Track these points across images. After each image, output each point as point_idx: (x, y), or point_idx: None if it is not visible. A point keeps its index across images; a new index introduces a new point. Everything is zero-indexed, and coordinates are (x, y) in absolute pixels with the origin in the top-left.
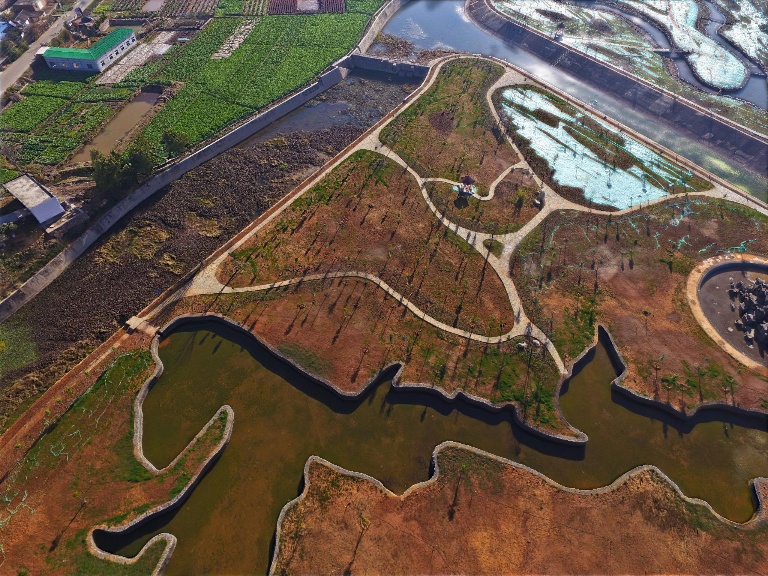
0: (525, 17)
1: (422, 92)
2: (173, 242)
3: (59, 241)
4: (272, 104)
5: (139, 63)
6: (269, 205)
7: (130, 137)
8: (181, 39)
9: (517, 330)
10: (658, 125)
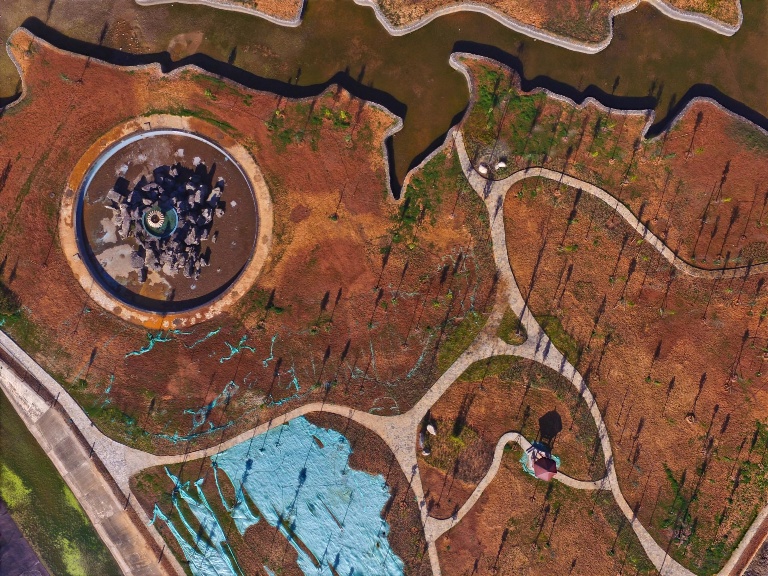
0: None
1: None
2: None
3: None
4: None
5: None
6: None
7: None
8: None
9: (503, 187)
10: None
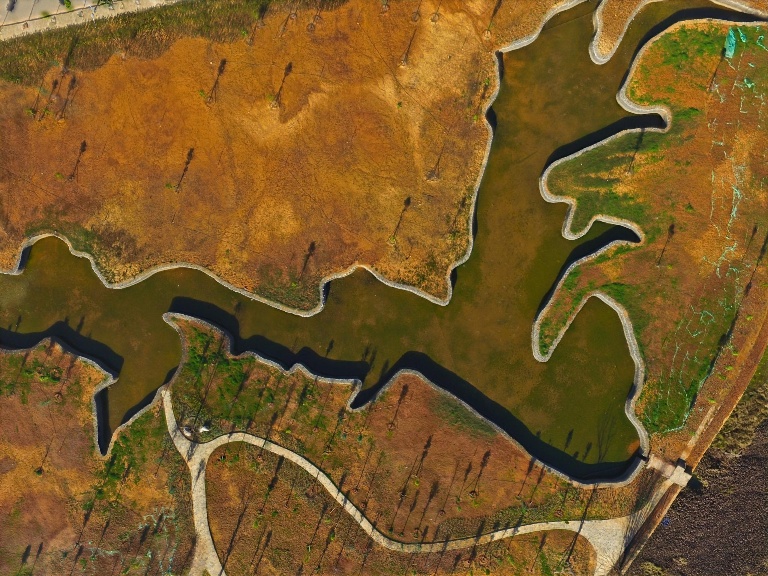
0: None
1: None
2: None
3: None
4: None
5: None
6: None
7: None
8: None
9: (206, 450)
10: None
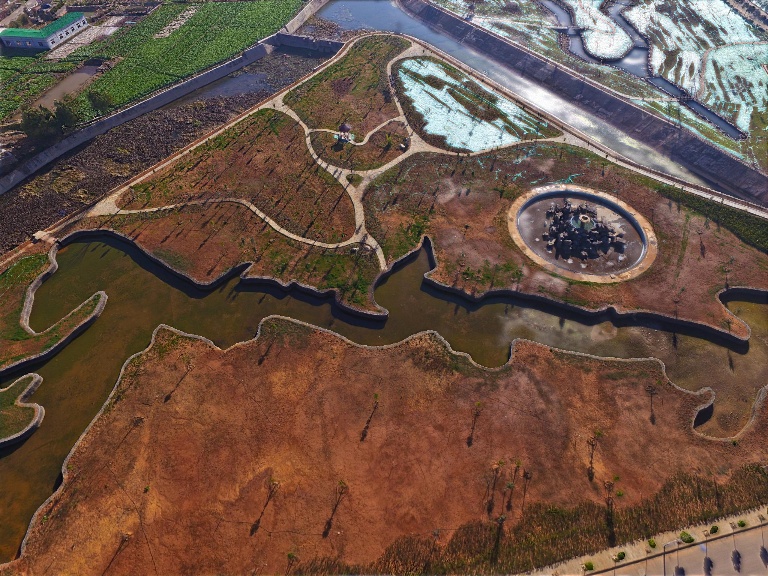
0: (445, 1)
1: (331, 63)
2: (88, 181)
3: None
4: (197, 74)
5: (86, 42)
6: None
7: (66, 100)
8: (128, 22)
9: (354, 239)
10: (539, 89)
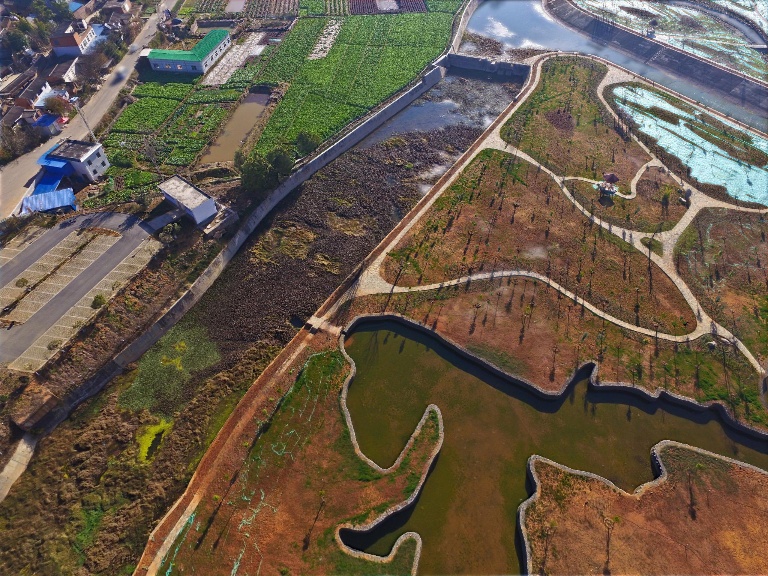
0: (611, 14)
1: (531, 91)
2: (322, 242)
3: (217, 242)
4: (382, 104)
5: (239, 64)
6: (407, 205)
7: (253, 138)
8: (273, 40)
9: (702, 329)
10: None
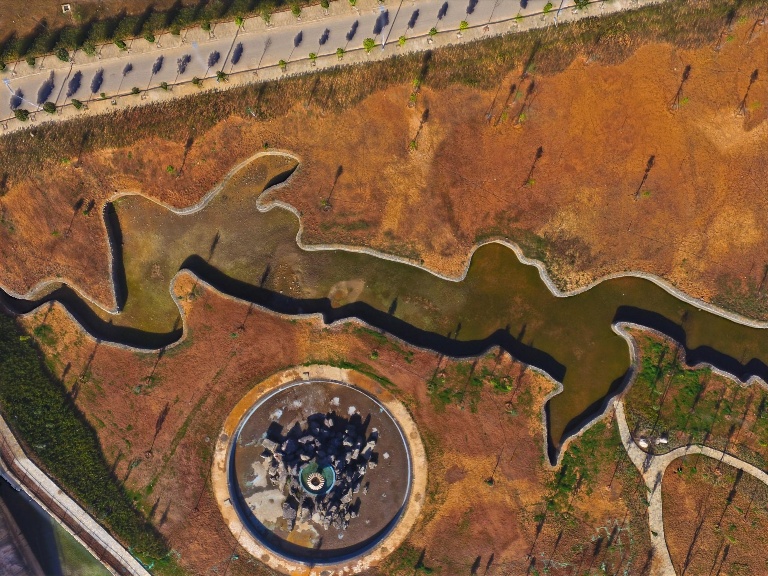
0: None
1: None
2: None
3: None
4: None
5: None
6: None
7: None
8: None
9: (663, 463)
10: None
